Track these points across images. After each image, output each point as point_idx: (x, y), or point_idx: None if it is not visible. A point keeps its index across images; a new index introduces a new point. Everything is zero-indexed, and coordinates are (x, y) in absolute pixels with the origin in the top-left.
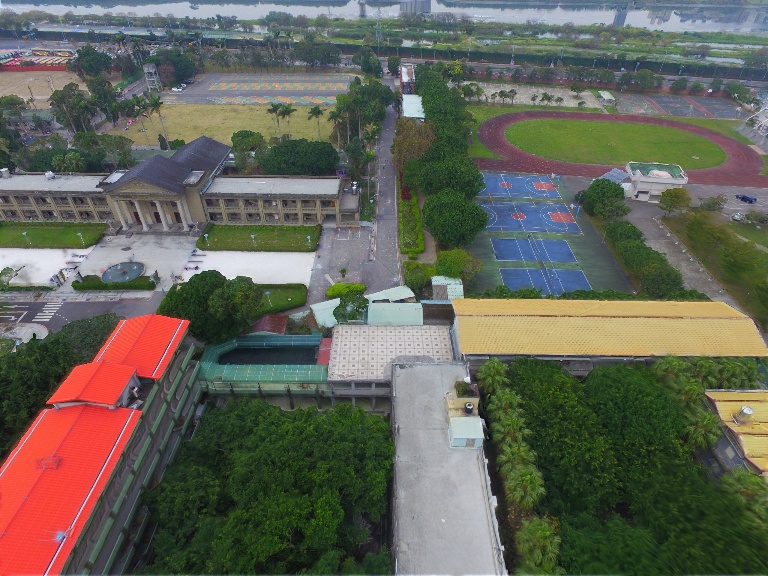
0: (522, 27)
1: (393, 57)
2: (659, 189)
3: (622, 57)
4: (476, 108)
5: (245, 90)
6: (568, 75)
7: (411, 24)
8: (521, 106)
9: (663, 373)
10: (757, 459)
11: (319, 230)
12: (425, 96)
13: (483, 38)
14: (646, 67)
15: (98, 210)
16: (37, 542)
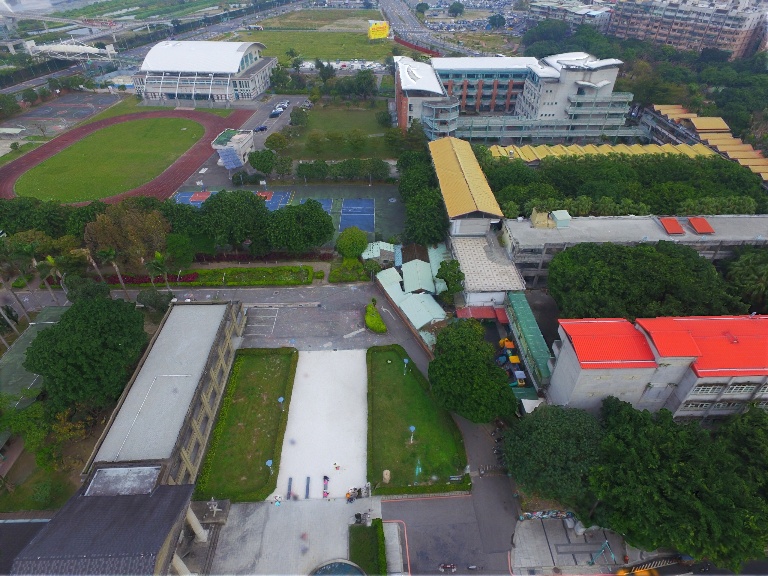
0: None
1: None
2: (247, 147)
3: None
4: None
5: None
6: None
7: None
8: None
9: (492, 165)
10: (531, 159)
11: (253, 349)
12: None
13: None
14: None
15: None
16: (764, 325)
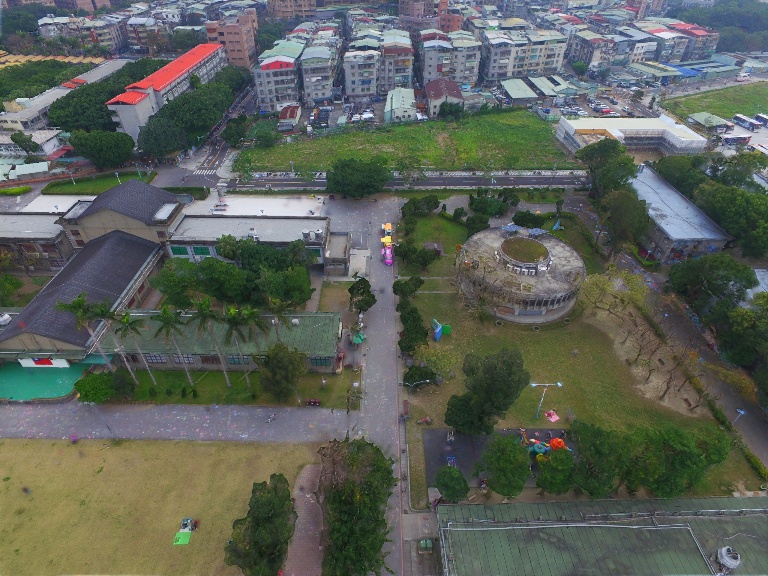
0: None
1: None
2: None
3: None
4: None
5: None
6: None
7: None
8: None
9: None
10: None
11: None
12: None
13: None
14: None
15: None
16: None
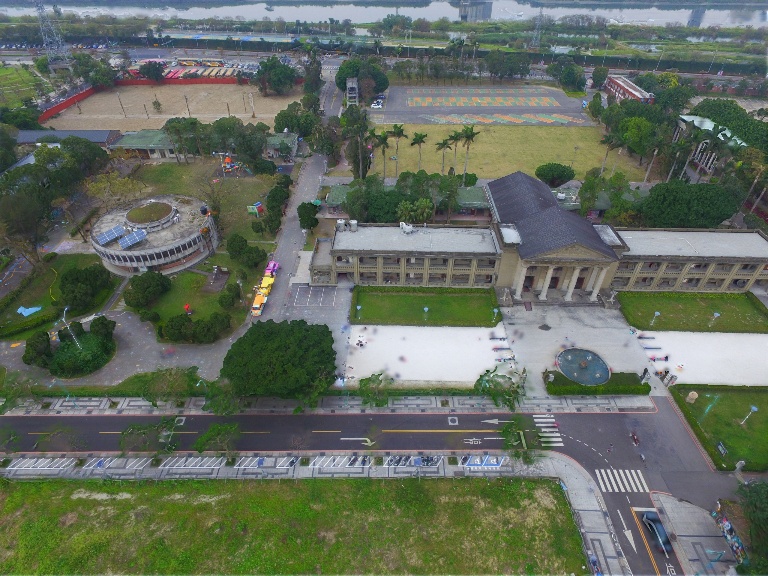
0: (661, 30)
1: (602, 68)
2: None
3: None
4: None
5: (450, 106)
6: None
7: None
8: None
9: None
10: None
11: (759, 300)
12: (721, 119)
13: (632, 43)
14: None
15: (478, 273)
16: None
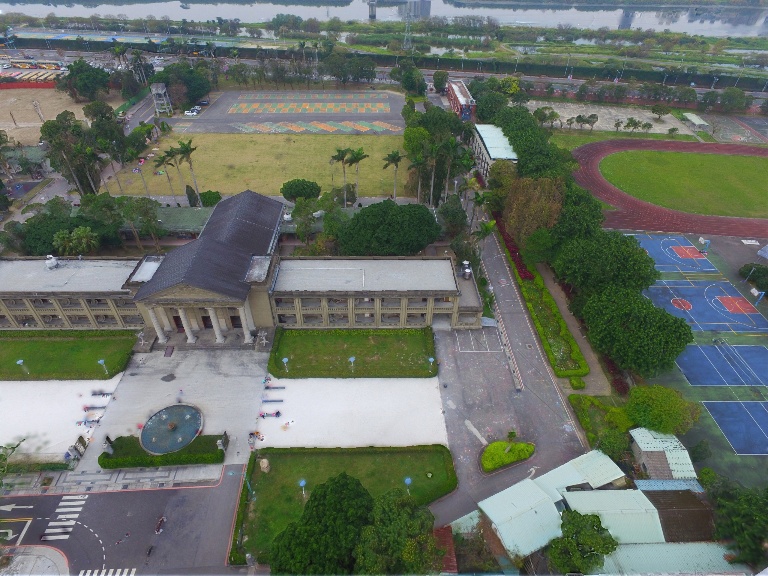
0: (553, 32)
1: (440, 72)
2: None
3: (693, 71)
4: (551, 136)
5: (272, 113)
6: (641, 93)
7: (432, 28)
8: (601, 133)
9: None
10: None
11: (432, 337)
12: (508, 128)
13: (516, 45)
14: (719, 82)
15: (122, 313)
16: None
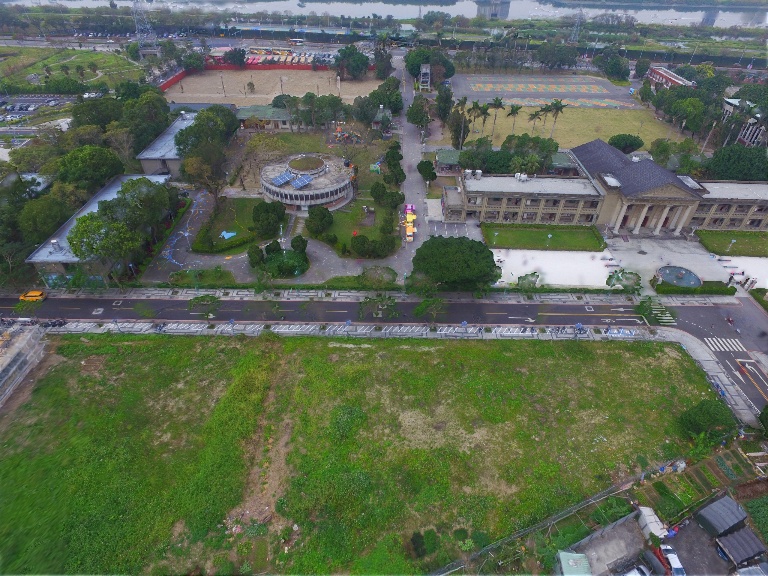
0: None
1: (645, 60)
2: None
3: None
4: None
5: (511, 91)
6: None
7: None
8: None
9: None
10: None
11: None
12: (762, 101)
13: (660, 40)
14: None
15: (582, 213)
16: None
